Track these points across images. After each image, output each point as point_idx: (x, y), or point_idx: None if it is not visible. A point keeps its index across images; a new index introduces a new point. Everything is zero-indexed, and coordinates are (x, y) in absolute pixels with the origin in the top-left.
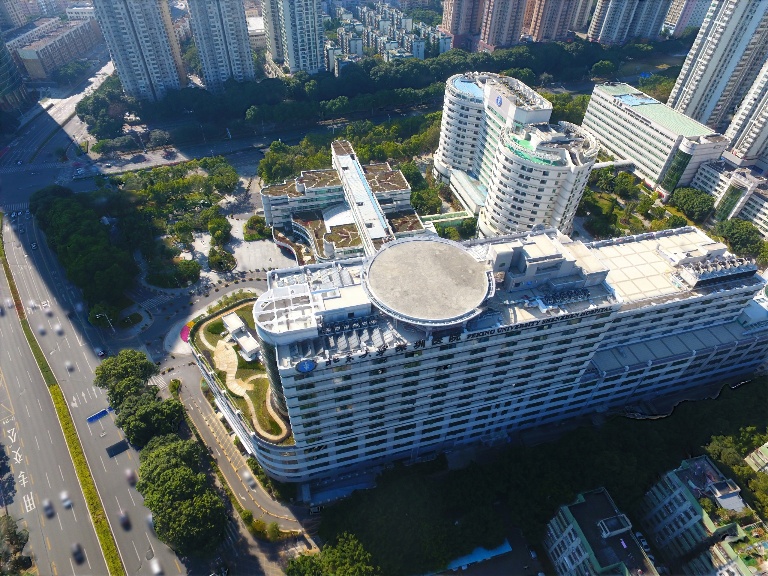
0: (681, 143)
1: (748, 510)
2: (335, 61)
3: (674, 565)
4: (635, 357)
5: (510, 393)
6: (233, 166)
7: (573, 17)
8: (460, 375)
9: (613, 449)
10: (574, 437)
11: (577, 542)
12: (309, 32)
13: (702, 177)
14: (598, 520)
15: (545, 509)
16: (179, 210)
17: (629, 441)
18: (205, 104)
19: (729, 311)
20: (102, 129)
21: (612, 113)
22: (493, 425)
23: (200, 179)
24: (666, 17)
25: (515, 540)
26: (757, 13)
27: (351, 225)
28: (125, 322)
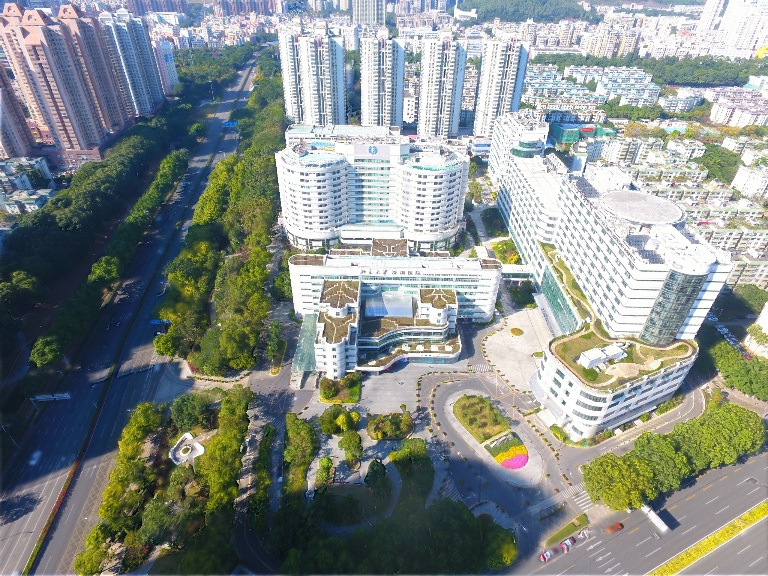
0: None
1: None
2: None
3: None
4: None
5: None
6: None
7: None
8: None
9: None
10: None
11: None
12: None
13: None
14: None
15: None
16: (265, 468)
17: None
18: None
19: None
20: None
21: None
22: None
23: (233, 417)
24: None
25: None
26: (338, 54)
27: (422, 291)
28: None
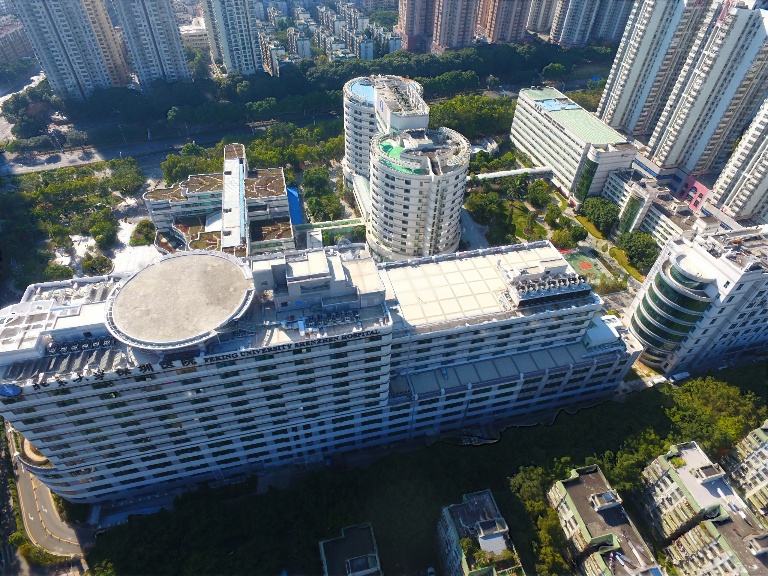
0: (589, 151)
1: (507, 553)
2: (276, 61)
3: None
4: (457, 379)
5: (302, 416)
6: (146, 168)
7: (537, 18)
8: (223, 399)
9: (417, 477)
10: (379, 463)
11: None
12: (242, 32)
13: (610, 186)
14: None
15: None
16: (70, 213)
17: (435, 469)
18: (129, 104)
19: (567, 332)
20: (22, 128)
21: (534, 118)
22: (302, 448)
23: (94, 181)
24: None
25: (296, 572)
26: (675, 16)
27: None
28: None
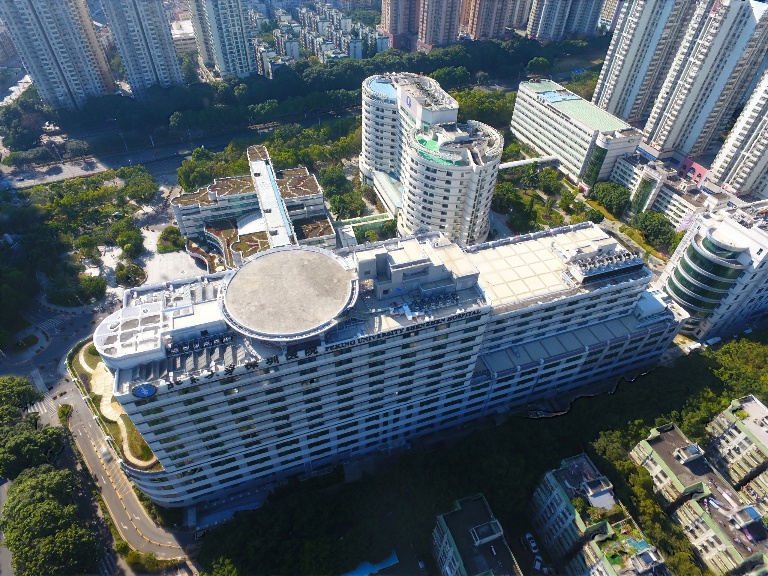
0: (597, 138)
1: (618, 507)
2: (268, 64)
3: (560, 565)
4: (529, 356)
5: (396, 401)
6: (155, 175)
7: (513, 15)
8: (331, 387)
9: (505, 451)
10: (466, 441)
11: (451, 551)
12: (236, 35)
13: (619, 171)
14: (472, 527)
15: (431, 518)
16: (89, 223)
17: (521, 442)
18: (127, 111)
19: (622, 305)
20: (15, 141)
21: (536, 110)
22: (388, 433)
23: (111, 190)
24: (602, 13)
25: (404, 551)
26: (665, 9)
27: (262, 233)
28: (18, 345)
